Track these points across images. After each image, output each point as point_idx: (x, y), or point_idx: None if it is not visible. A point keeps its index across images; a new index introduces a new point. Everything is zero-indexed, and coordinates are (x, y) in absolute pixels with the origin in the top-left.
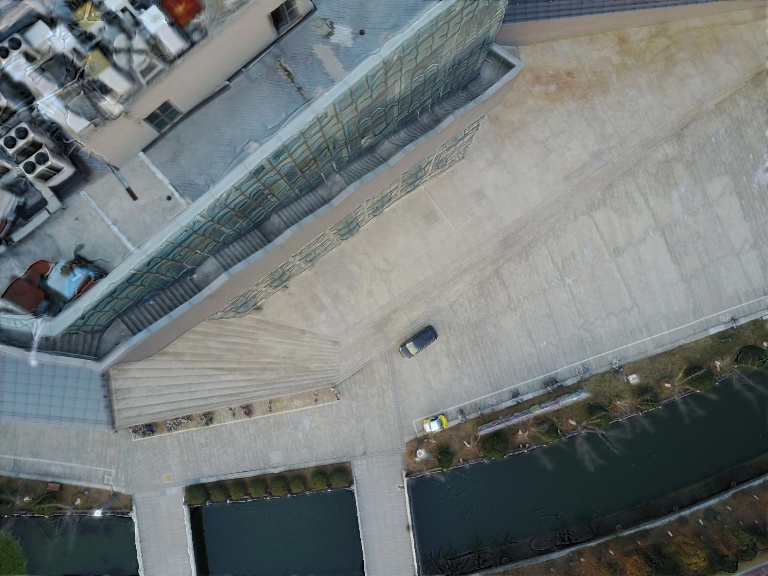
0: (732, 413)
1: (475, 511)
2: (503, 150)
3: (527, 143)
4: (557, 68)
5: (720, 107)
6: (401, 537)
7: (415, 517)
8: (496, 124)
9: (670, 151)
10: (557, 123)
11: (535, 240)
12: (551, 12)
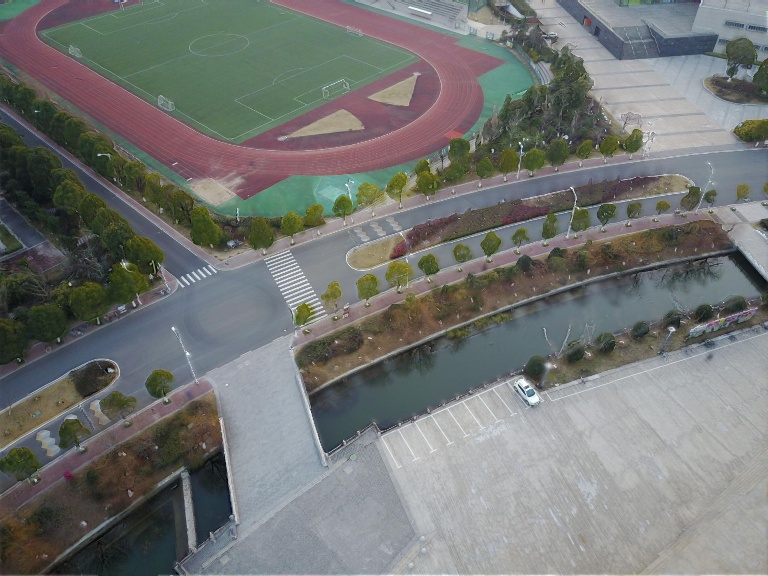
0: (535, 349)
1: (698, 300)
2: None
3: None
4: None
5: (653, 555)
6: (766, 268)
7: (750, 287)
8: None
9: (686, 512)
10: None
11: None
12: None
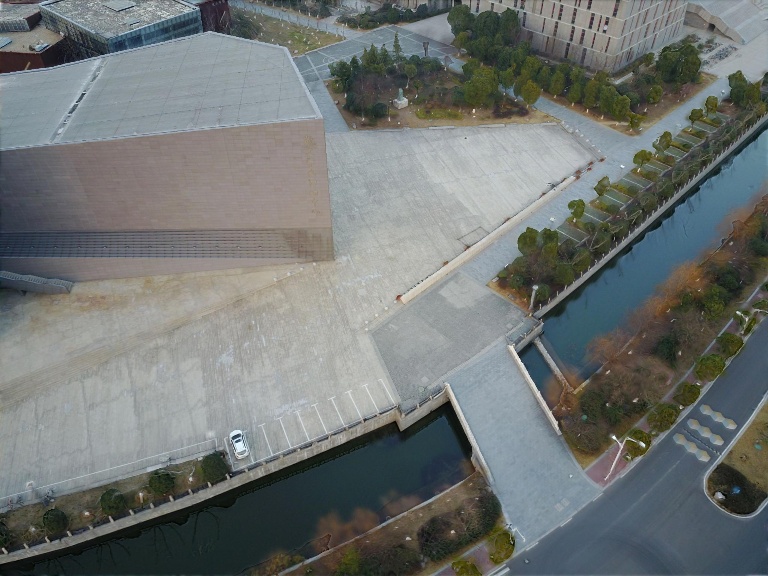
0: None
1: None
2: (30, 336)
3: (51, 332)
4: (96, 294)
5: (206, 318)
6: None
7: None
8: (34, 322)
9: (160, 342)
10: (79, 322)
11: (29, 397)
12: (80, 254)
